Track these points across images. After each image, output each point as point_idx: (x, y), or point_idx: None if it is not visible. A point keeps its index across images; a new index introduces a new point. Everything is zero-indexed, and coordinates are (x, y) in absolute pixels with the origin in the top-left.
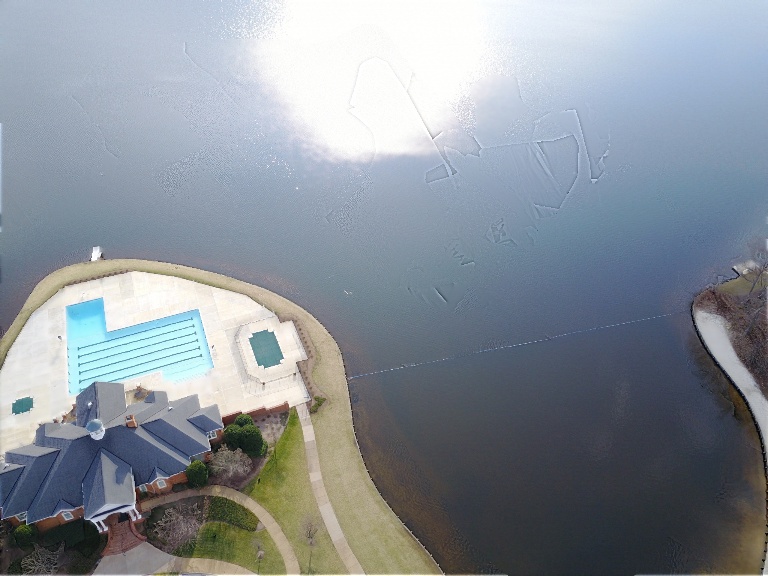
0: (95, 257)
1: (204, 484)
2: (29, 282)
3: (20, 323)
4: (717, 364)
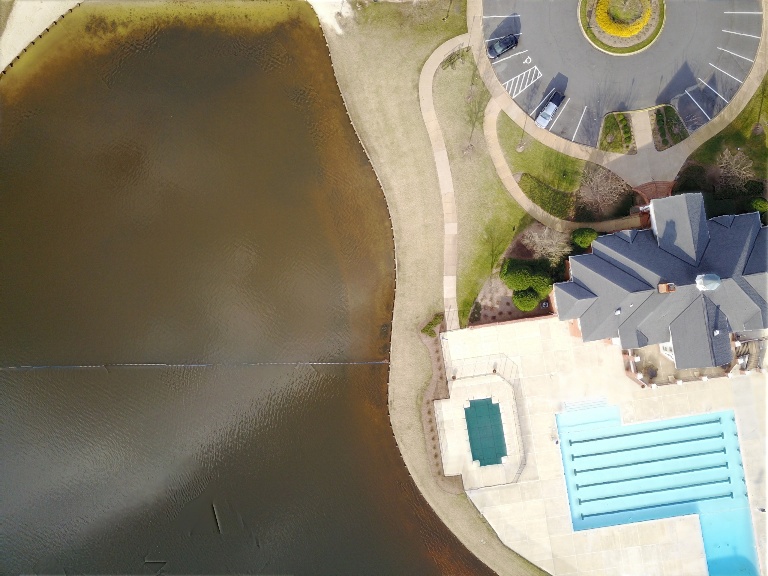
0: None
1: None
2: None
3: None
4: None
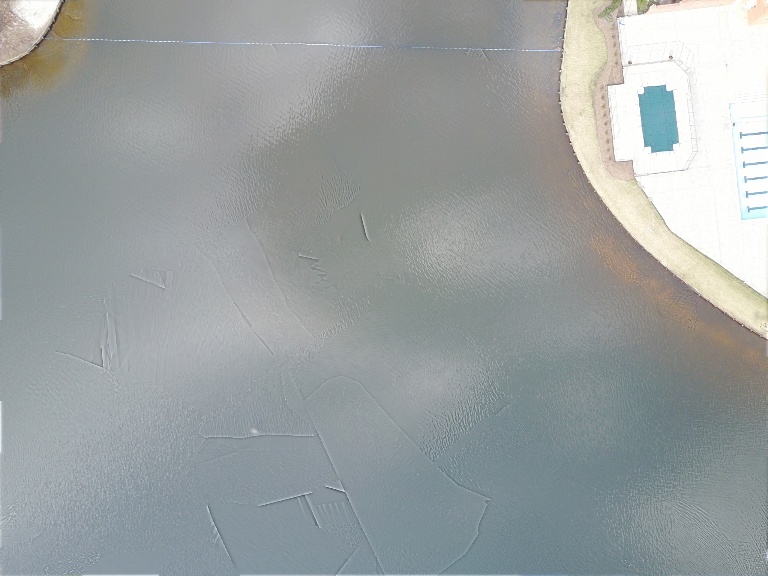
0: None
1: None
2: None
3: None
4: None
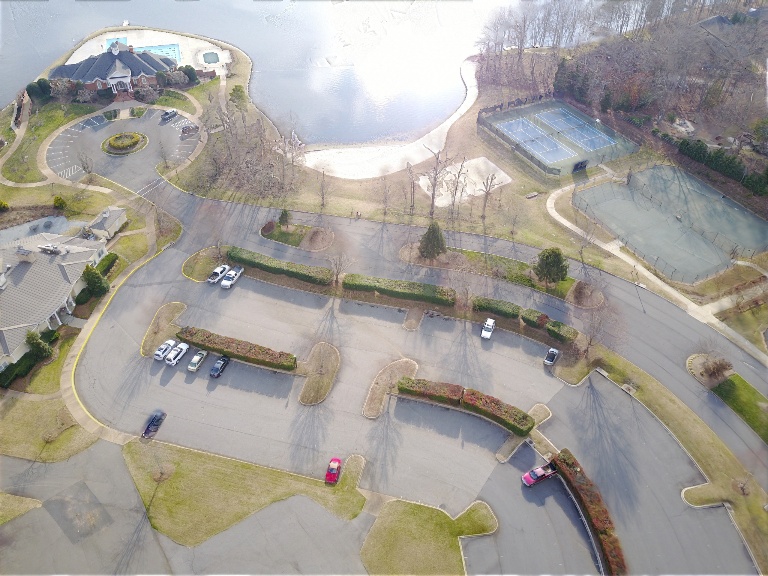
0: (125, 25)
1: (165, 85)
2: (87, 33)
3: (81, 44)
4: (462, 78)
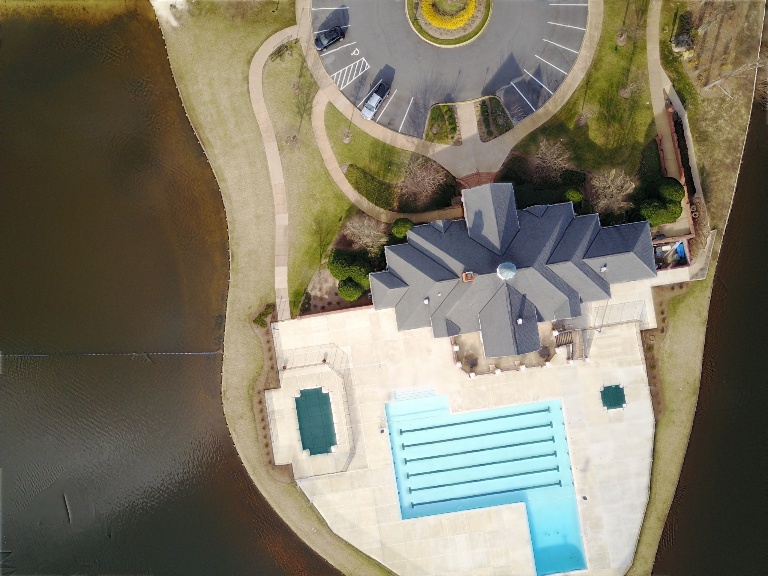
0: None
1: None
2: None
3: (645, 550)
4: None
